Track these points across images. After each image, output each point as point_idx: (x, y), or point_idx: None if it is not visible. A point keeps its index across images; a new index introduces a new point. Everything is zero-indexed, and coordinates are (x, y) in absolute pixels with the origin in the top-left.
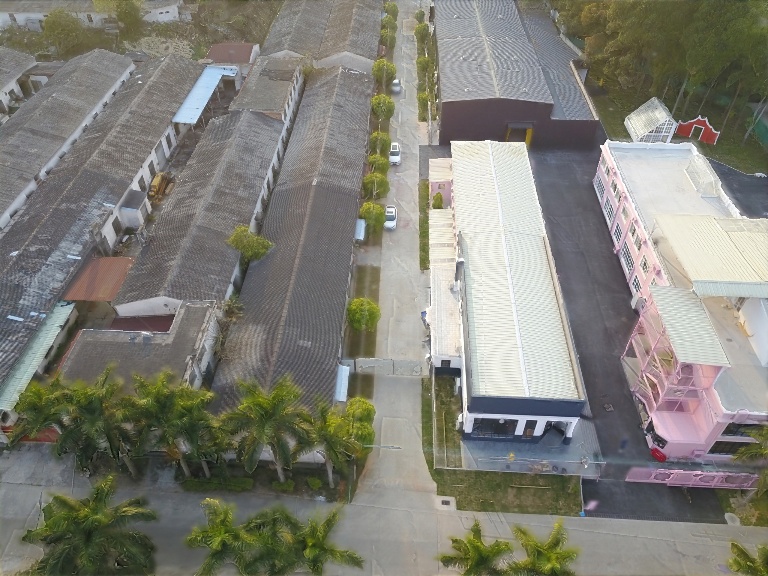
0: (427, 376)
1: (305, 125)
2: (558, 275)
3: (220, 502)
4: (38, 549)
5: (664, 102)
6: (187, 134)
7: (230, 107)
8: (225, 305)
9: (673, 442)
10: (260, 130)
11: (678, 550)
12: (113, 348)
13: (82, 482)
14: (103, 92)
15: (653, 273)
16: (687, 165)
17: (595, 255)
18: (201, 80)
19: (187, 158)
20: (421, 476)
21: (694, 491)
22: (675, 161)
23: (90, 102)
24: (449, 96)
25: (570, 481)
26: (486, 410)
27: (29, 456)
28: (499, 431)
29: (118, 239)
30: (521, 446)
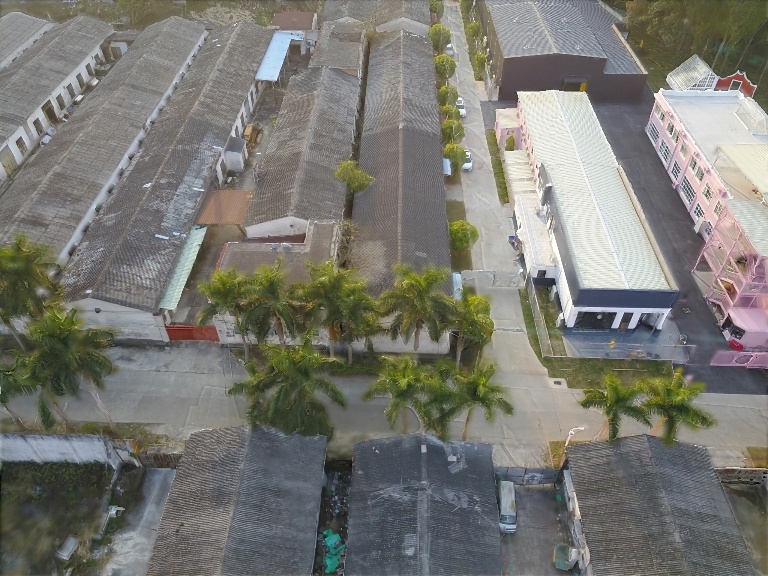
0: (523, 287)
1: (378, 81)
2: None
3: (363, 384)
4: (214, 420)
5: None
6: (264, 93)
7: (310, 64)
8: (344, 225)
9: (751, 331)
10: (340, 84)
11: (763, 415)
12: (259, 256)
13: (239, 370)
14: (186, 54)
15: (718, 196)
16: (736, 109)
17: (656, 190)
18: (273, 44)
19: (269, 113)
20: (532, 363)
21: None
22: (725, 106)
23: (177, 62)
24: (510, 53)
25: (663, 365)
26: (590, 303)
27: (188, 351)
28: (597, 326)
29: (224, 180)
30: (616, 339)
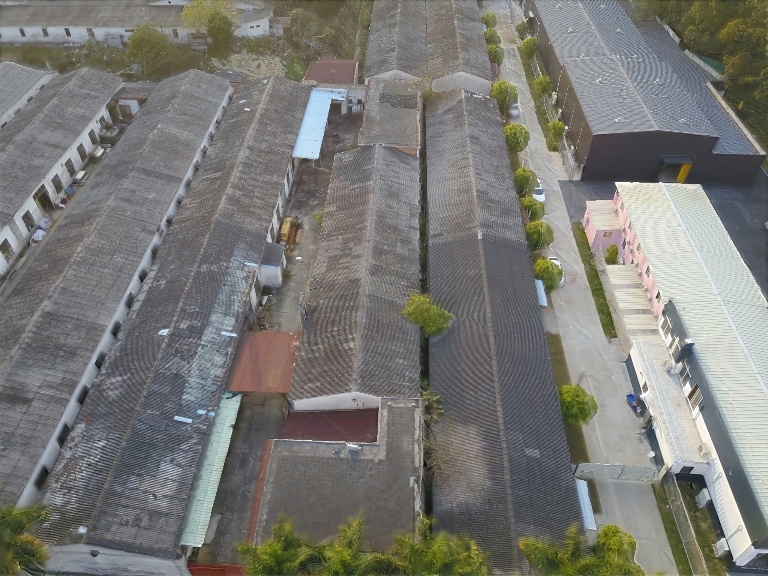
0: (658, 481)
1: (441, 161)
2: None
3: None
4: None
5: None
6: (300, 168)
7: (359, 141)
8: (424, 400)
9: None
10: (398, 169)
11: None
12: (317, 466)
13: None
14: (208, 121)
15: None
16: None
17: None
18: (310, 105)
19: (308, 197)
20: None
21: None
22: None
23: (198, 134)
24: (600, 127)
25: None
26: None
27: None
28: None
29: (257, 301)
30: None
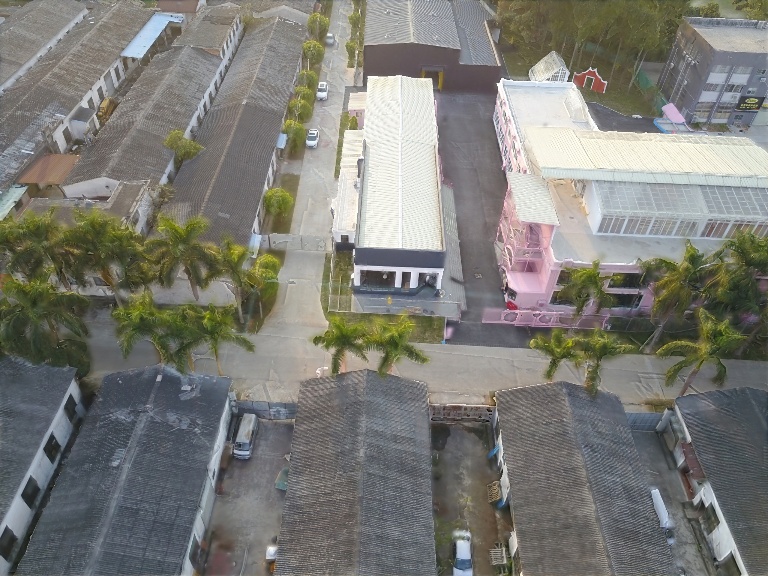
0: (330, 251)
1: (241, 62)
2: (451, 183)
3: None
4: None
5: (566, 60)
6: (135, 71)
7: (173, 43)
8: (158, 187)
9: (520, 292)
10: (199, 63)
11: (514, 365)
12: (60, 210)
13: None
14: (57, 29)
15: None
16: None
17: (486, 171)
18: (149, 24)
19: None
20: (317, 317)
21: (535, 329)
22: (557, 96)
23: (45, 37)
24: (370, 41)
25: (436, 320)
26: (369, 262)
27: None
28: (383, 285)
29: (68, 147)
30: (401, 298)
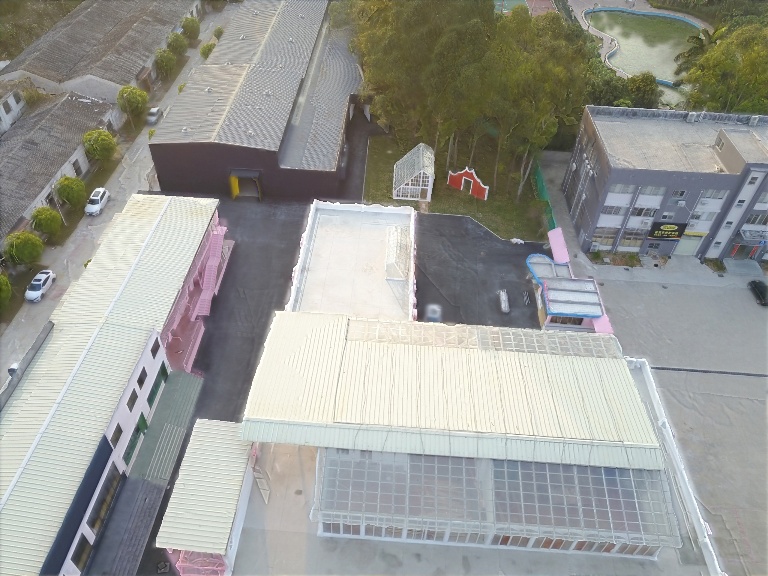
0: None
1: None
2: (198, 372)
3: None
4: None
5: None
6: None
7: None
8: None
9: None
10: None
11: None
12: None
13: None
14: None
15: None
16: None
17: None
18: None
19: None
20: None
21: None
22: (384, 229)
23: None
24: (160, 137)
25: None
26: None
27: None
28: None
29: None
30: None
